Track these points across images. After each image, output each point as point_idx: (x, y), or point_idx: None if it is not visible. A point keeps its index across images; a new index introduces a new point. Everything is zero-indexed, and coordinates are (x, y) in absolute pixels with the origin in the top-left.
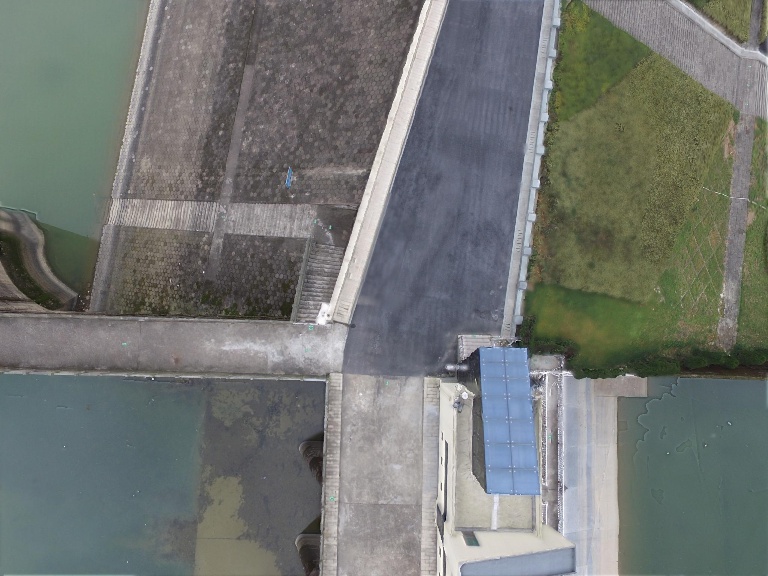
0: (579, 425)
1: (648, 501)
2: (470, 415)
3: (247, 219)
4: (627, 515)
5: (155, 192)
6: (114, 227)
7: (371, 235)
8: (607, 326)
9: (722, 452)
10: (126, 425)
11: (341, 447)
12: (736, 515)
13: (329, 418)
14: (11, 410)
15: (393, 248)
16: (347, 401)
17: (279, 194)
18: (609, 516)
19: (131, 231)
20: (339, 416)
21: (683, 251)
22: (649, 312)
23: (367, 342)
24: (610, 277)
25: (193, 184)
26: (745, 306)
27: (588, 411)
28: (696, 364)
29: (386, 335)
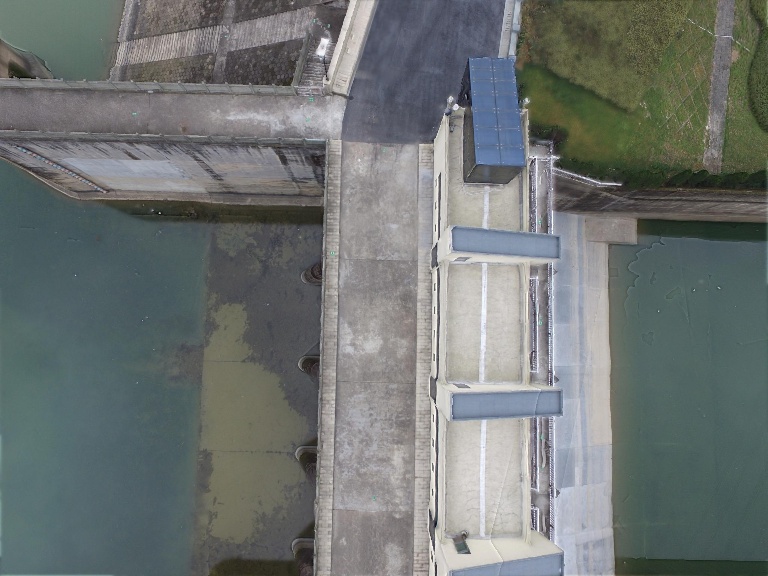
0: (571, 266)
1: (639, 349)
2: (461, 135)
3: (249, 34)
4: (618, 357)
5: (160, 28)
6: (121, 67)
7: (367, 13)
8: (595, 131)
9: (711, 311)
10: (134, 257)
11: (341, 208)
12: (724, 363)
13: (329, 180)
14: (24, 241)
15: (388, 27)
16: (346, 166)
17: (280, 4)
18: (601, 355)
19: (137, 67)
20: (339, 178)
21: (668, 74)
22: (636, 125)
23: (365, 112)
24: (597, 75)
25: (197, 13)
26: (730, 138)
27: (580, 254)
28: (681, 176)
29: (382, 106)
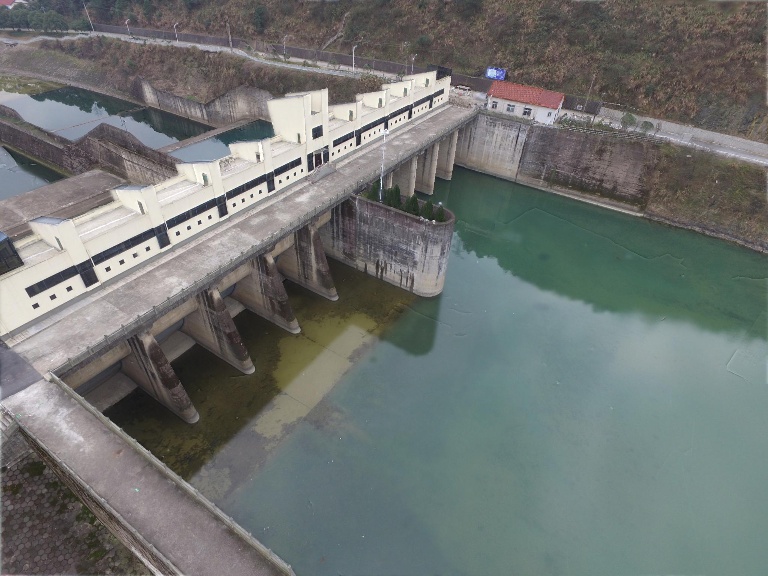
0: None
1: None
2: None
3: None
4: None
5: None
6: None
7: None
8: None
9: None
10: (305, 524)
11: None
12: None
13: None
14: None
15: None
16: None
17: None
18: None
19: None
20: None
21: None
22: None
23: (5, 385)
24: None
25: None
26: None
27: None
28: None
29: None
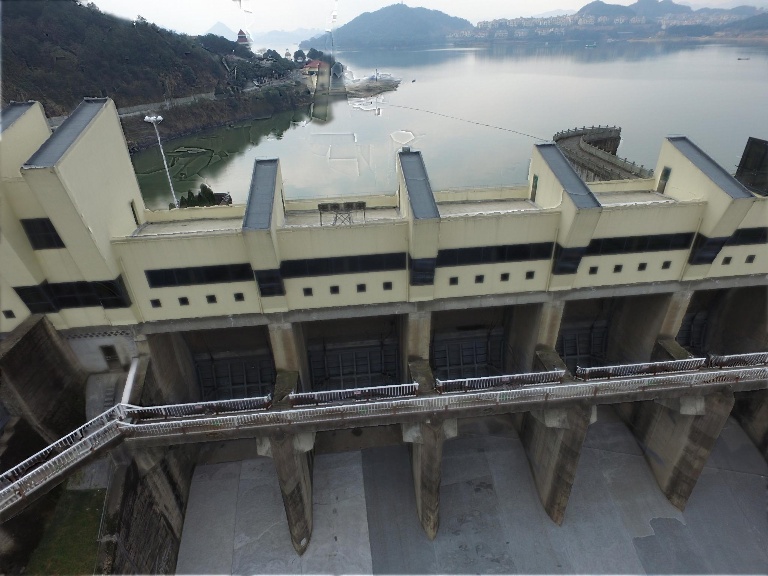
0: None
1: None
2: None
3: None
4: None
5: None
6: None
7: None
8: None
9: None
10: None
11: None
12: None
13: None
14: None
15: None
16: None
17: None
18: None
19: None
20: None
21: None
22: None
23: None
24: None
25: None
26: None
27: None
28: None
29: None
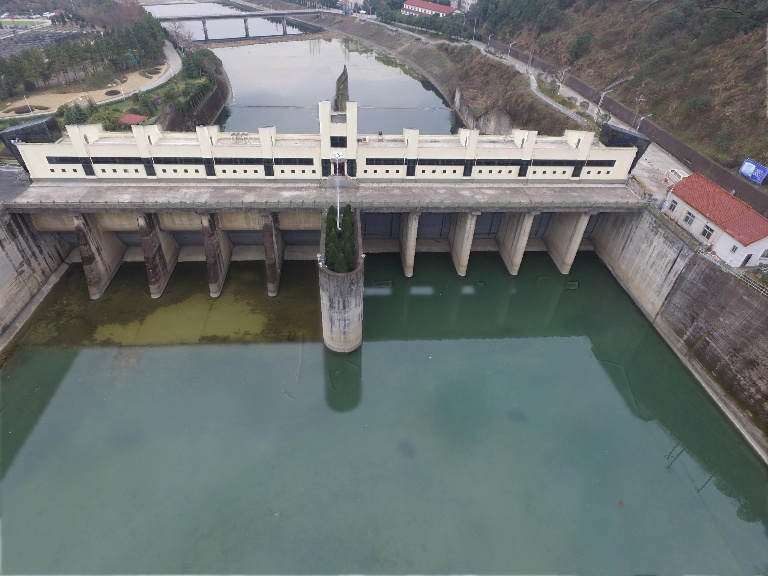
0: None
1: None
2: None
3: None
4: None
5: None
6: None
7: None
8: None
9: None
10: (20, 396)
11: None
12: None
13: None
14: None
15: None
16: None
17: None
18: None
19: None
20: None
21: None
22: None
23: None
24: None
25: None
26: None
27: None
28: None
29: None
